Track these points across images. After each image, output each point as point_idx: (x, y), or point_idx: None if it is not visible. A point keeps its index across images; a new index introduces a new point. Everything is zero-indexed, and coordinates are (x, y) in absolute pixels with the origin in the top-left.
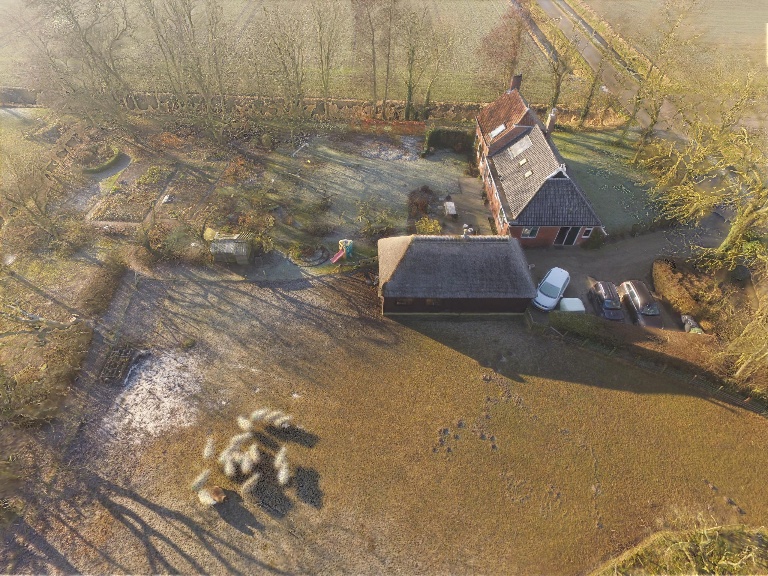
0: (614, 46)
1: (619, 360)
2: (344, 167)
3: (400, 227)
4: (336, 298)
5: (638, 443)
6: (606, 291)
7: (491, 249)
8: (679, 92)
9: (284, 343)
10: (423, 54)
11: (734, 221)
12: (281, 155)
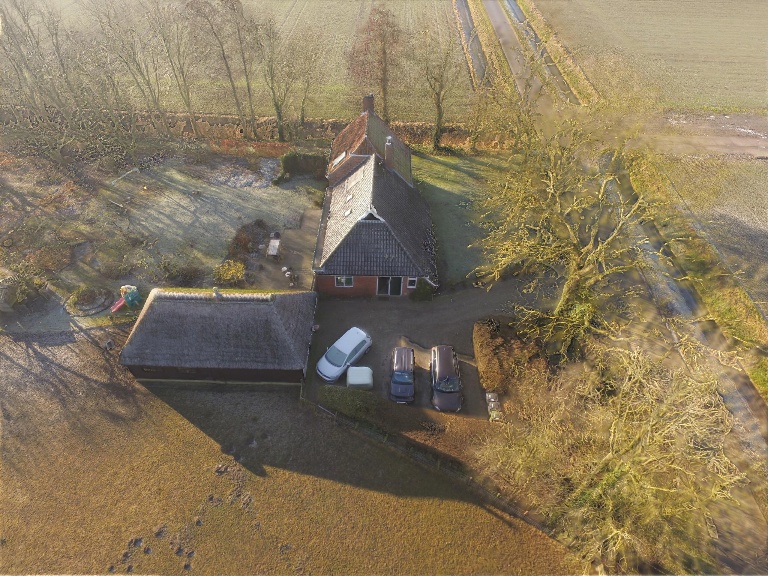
0: (554, 57)
1: (393, 449)
2: (182, 195)
3: (211, 269)
4: (94, 357)
5: (371, 568)
6: (398, 361)
7: (248, 311)
8: (602, 110)
9: (5, 414)
10: (287, 69)
11: (528, 288)
12: (121, 179)
